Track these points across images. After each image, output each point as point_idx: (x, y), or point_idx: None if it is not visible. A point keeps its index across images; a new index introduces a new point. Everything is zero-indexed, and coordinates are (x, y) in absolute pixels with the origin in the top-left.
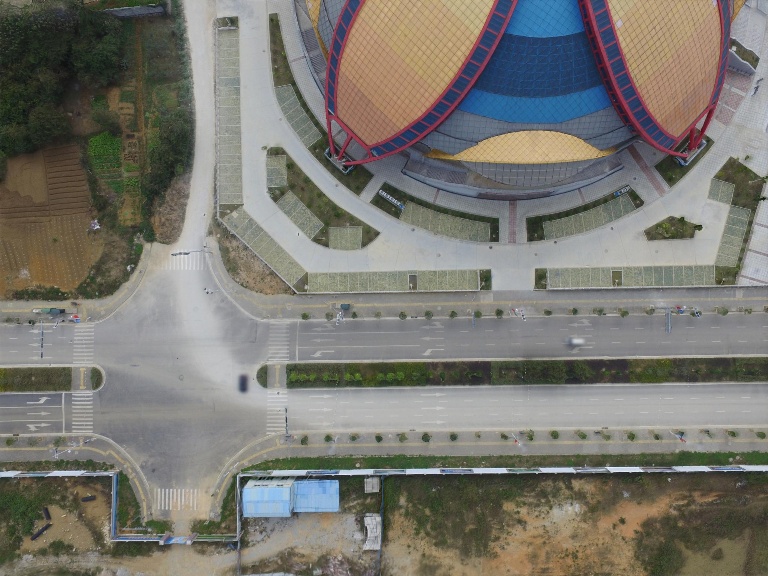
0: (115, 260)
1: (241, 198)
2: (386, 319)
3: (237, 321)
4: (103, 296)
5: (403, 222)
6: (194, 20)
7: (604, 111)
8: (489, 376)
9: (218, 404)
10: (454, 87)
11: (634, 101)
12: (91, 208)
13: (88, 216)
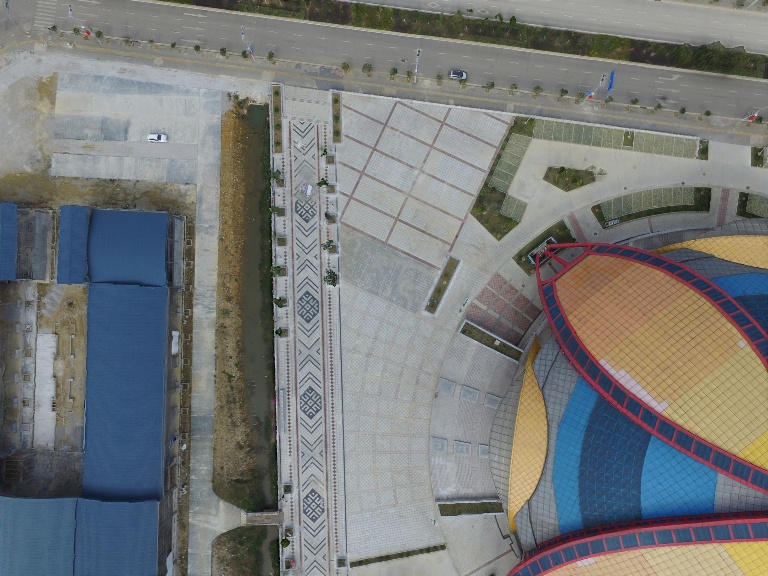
0: None
1: None
2: None
3: None
4: None
5: None
6: None
7: None
8: (767, 64)
9: None
10: None
11: (688, 279)
12: None
13: None
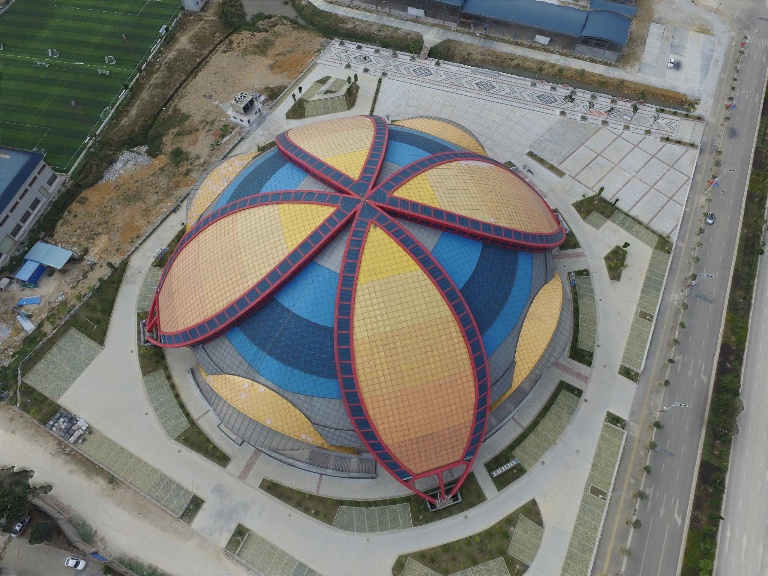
0: None
1: None
2: (629, 545)
3: None
4: None
5: (531, 469)
6: None
7: (534, 260)
8: (718, 468)
9: None
10: (474, 354)
11: (539, 238)
12: None
13: None
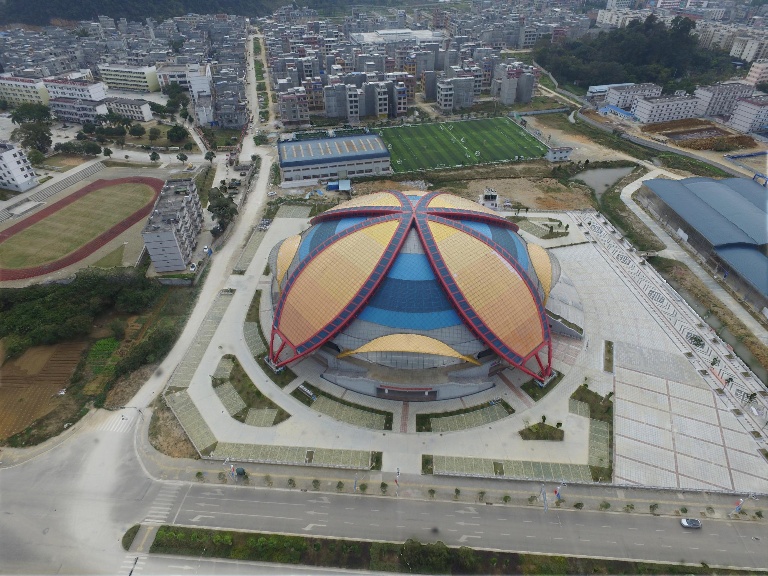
0: (59, 418)
1: (188, 384)
2: (276, 490)
3: (134, 479)
4: (27, 446)
5: (313, 410)
6: (208, 289)
7: (458, 327)
8: (368, 558)
9: (66, 566)
10: (353, 302)
11: (476, 320)
12: (67, 381)
13: (61, 386)
